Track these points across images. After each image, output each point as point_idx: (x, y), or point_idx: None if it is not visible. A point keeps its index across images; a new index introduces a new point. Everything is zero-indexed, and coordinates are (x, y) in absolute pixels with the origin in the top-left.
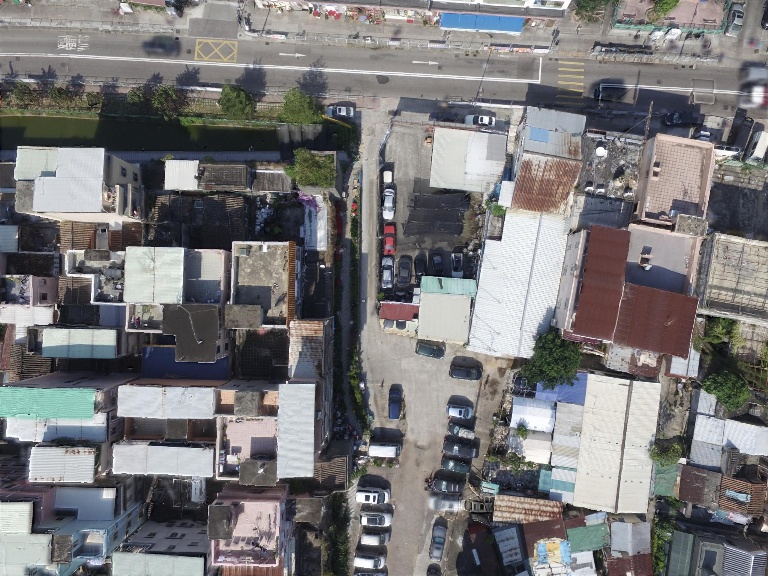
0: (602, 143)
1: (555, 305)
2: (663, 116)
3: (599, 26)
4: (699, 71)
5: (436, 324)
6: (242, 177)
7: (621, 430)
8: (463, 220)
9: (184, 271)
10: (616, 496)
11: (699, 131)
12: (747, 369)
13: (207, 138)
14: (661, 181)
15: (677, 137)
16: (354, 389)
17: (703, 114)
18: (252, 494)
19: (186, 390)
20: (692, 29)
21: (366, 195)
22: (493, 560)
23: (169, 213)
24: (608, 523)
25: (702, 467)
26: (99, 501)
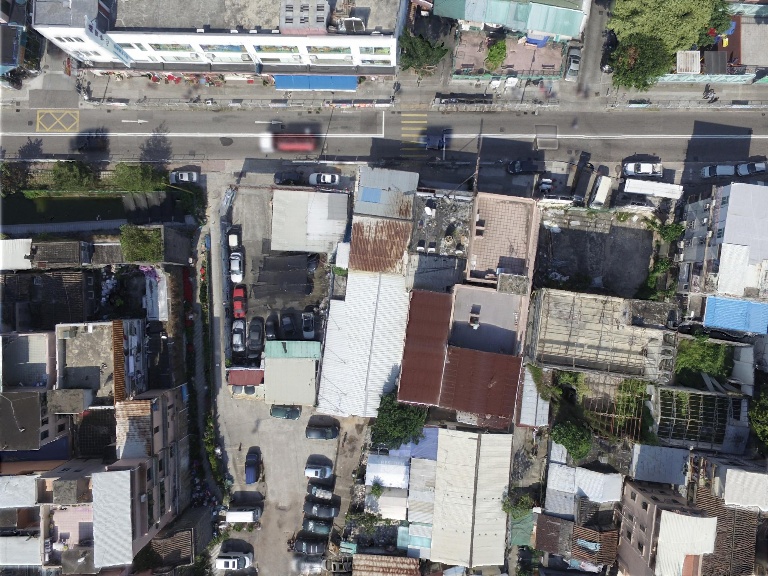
0: (432, 201)
1: (400, 363)
2: (506, 164)
3: (439, 77)
4: (542, 117)
5: (282, 388)
6: (75, 254)
7: (472, 484)
8: (313, 279)
9: (3, 359)
10: (470, 550)
11: (541, 178)
12: (592, 417)
13: (53, 209)
14: (487, 239)
15: (498, 195)
16: (209, 455)
17: (543, 162)
18: None
19: (11, 479)
20: (530, 76)
21: (215, 259)
22: None
23: (5, 293)
24: None
25: (556, 516)
26: None
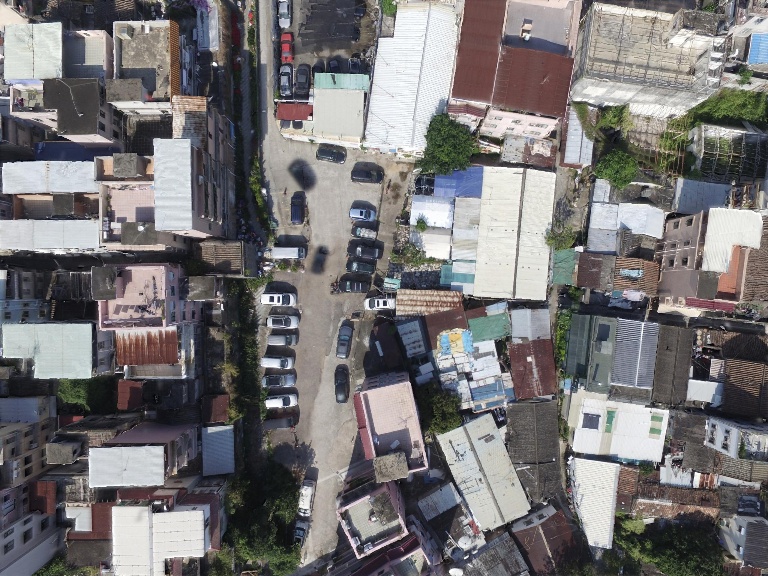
0: None
1: (448, 97)
2: None
3: None
4: None
5: (330, 119)
6: None
7: (516, 217)
8: (360, 28)
9: (62, 45)
10: (513, 281)
11: None
12: (637, 150)
13: None
14: None
15: None
16: (255, 194)
17: None
18: (139, 264)
19: (69, 163)
20: None
21: (263, 6)
22: (396, 351)
23: (59, 15)
24: (509, 313)
25: (598, 252)
26: None
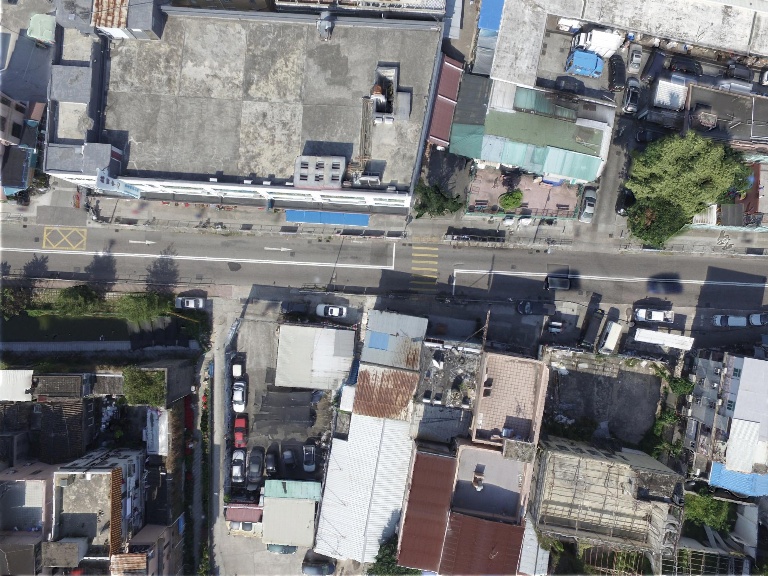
0: (440, 352)
1: (401, 507)
2: (516, 304)
3: None
4: (554, 255)
5: (280, 529)
6: (76, 388)
7: None
8: (316, 410)
9: None
10: None
11: (551, 321)
12: (592, 573)
13: (57, 327)
14: (494, 397)
15: (508, 356)
16: None
17: (554, 305)
18: None
19: None
20: (544, 217)
21: (218, 385)
22: None
23: (4, 423)
24: None
25: None
26: None
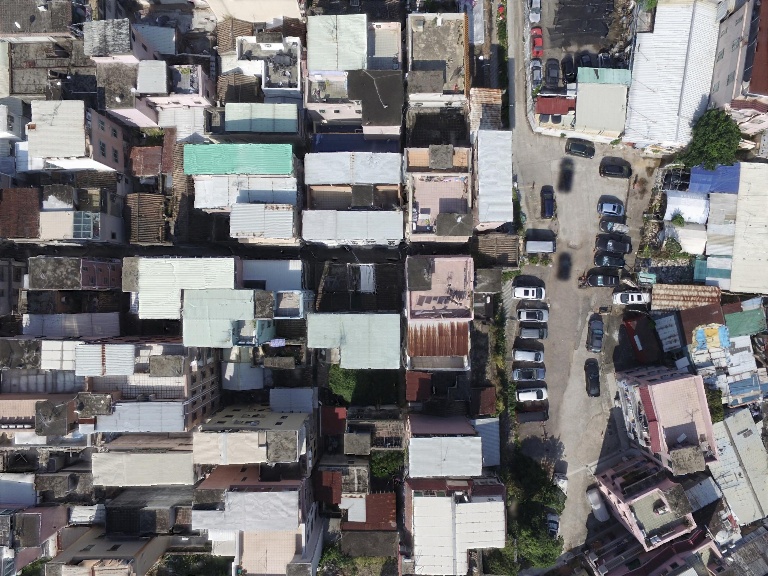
0: None
1: (709, 93)
2: None
3: None
4: None
5: (593, 114)
6: None
7: None
8: (607, 23)
9: None
10: None
11: None
12: None
13: None
14: None
15: None
16: None
17: None
18: (442, 255)
19: (373, 155)
20: None
21: (511, 1)
22: (655, 345)
23: (329, 7)
24: (764, 308)
25: None
26: (286, 273)
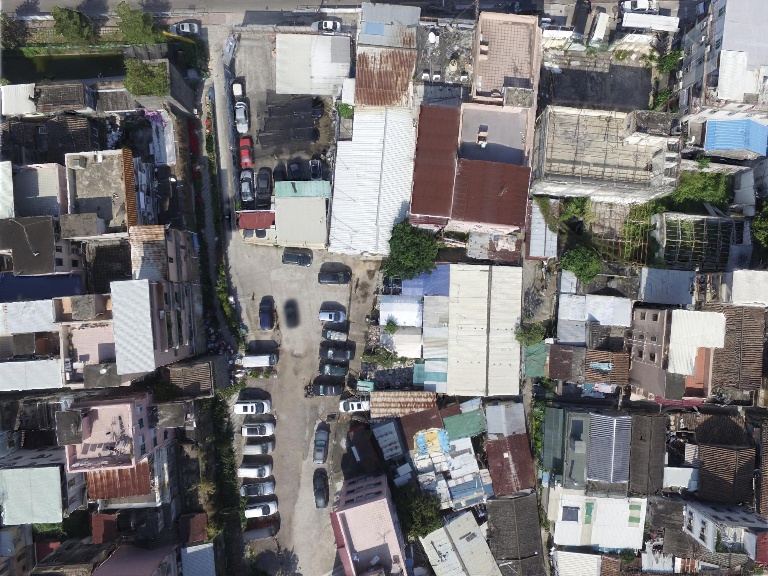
0: (435, 30)
1: None
2: (506, 7)
3: None
4: None
5: (293, 228)
6: (80, 96)
7: (485, 315)
8: (319, 128)
9: (13, 185)
10: (486, 379)
11: (541, 18)
12: (600, 242)
13: (54, 68)
14: (491, 60)
15: (501, 14)
16: (223, 303)
17: (542, 0)
18: (105, 401)
19: (28, 304)
20: None
21: (220, 111)
22: (372, 455)
23: (11, 139)
24: (483, 408)
25: (568, 344)
26: None
